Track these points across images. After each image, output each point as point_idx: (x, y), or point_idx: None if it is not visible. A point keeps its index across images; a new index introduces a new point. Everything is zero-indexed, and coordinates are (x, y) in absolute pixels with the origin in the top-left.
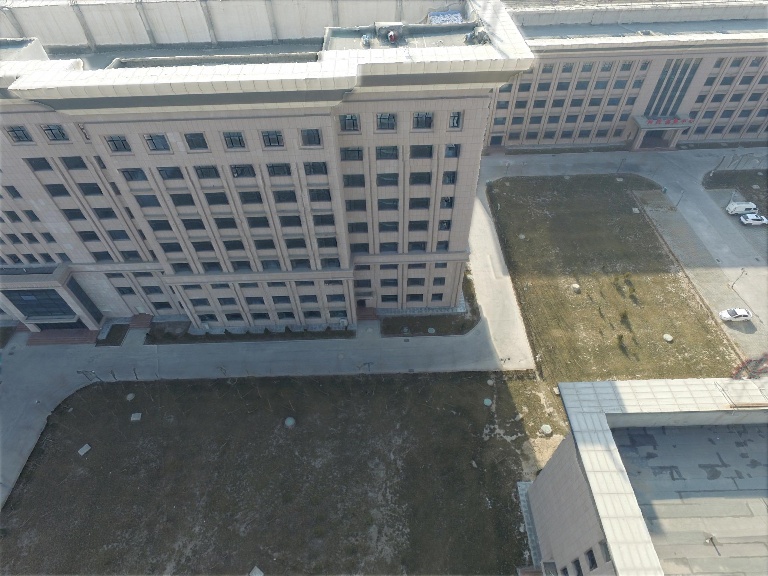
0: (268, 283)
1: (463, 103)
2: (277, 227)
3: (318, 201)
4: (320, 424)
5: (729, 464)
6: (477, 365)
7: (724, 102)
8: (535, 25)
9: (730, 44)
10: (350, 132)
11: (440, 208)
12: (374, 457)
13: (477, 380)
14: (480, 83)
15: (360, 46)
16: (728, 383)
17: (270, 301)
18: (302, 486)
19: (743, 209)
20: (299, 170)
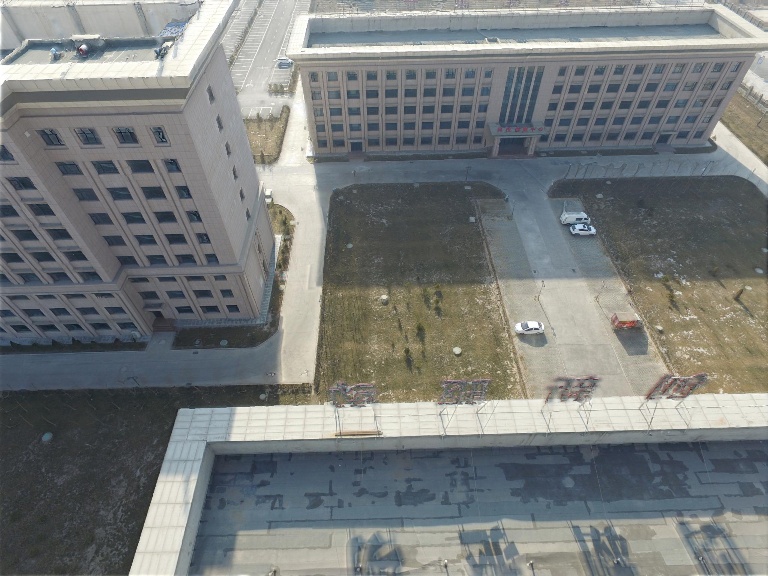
0: (38, 295)
1: (157, 119)
2: (14, 241)
3: (45, 215)
4: (77, 439)
5: (336, 492)
6: (257, 378)
7: (577, 110)
8: (394, 30)
9: (566, 53)
10: (57, 147)
11: (190, 222)
12: (120, 474)
13: (250, 394)
14: (157, 100)
15: (48, 60)
16: (348, 410)
17: (50, 313)
18: (36, 504)
19: (574, 219)
20: (5, 185)
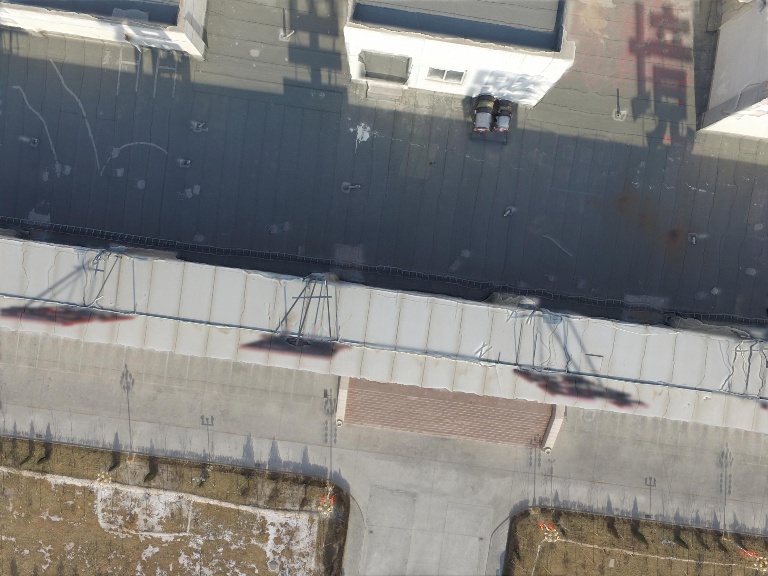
0: None
1: None
2: None
3: None
4: None
5: None
6: None
7: None
8: None
9: None
10: None
11: None
12: None
13: None
14: None
15: None
16: None
17: None
18: None
19: None
20: None
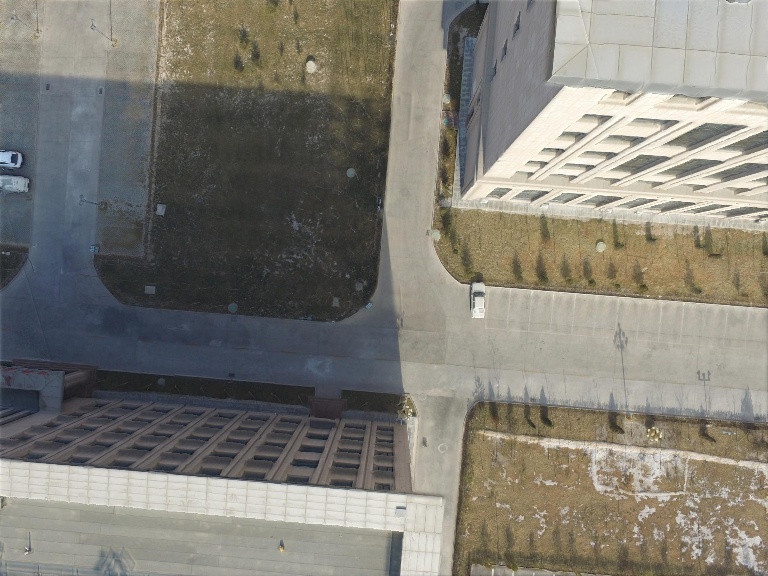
0: None
1: None
2: None
3: None
4: None
5: None
6: None
7: None
8: None
9: None
10: None
11: None
12: None
13: None
14: None
15: None
16: None
17: None
18: None
19: None
20: None
